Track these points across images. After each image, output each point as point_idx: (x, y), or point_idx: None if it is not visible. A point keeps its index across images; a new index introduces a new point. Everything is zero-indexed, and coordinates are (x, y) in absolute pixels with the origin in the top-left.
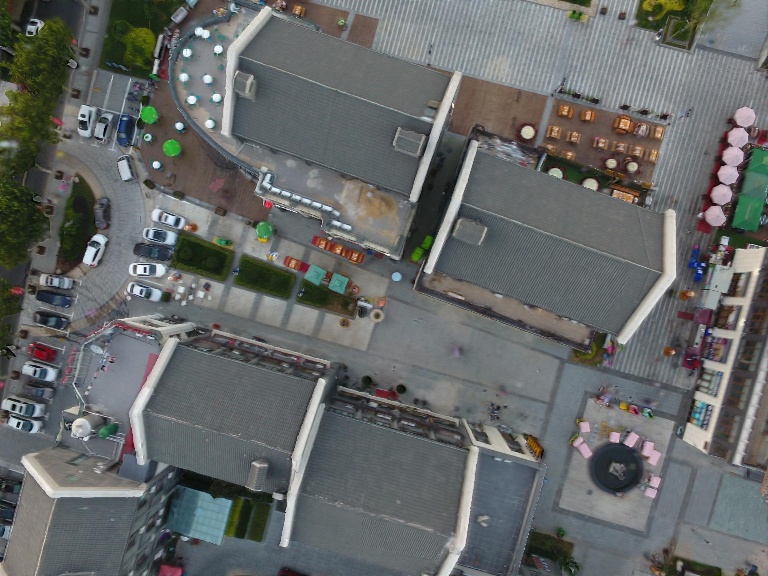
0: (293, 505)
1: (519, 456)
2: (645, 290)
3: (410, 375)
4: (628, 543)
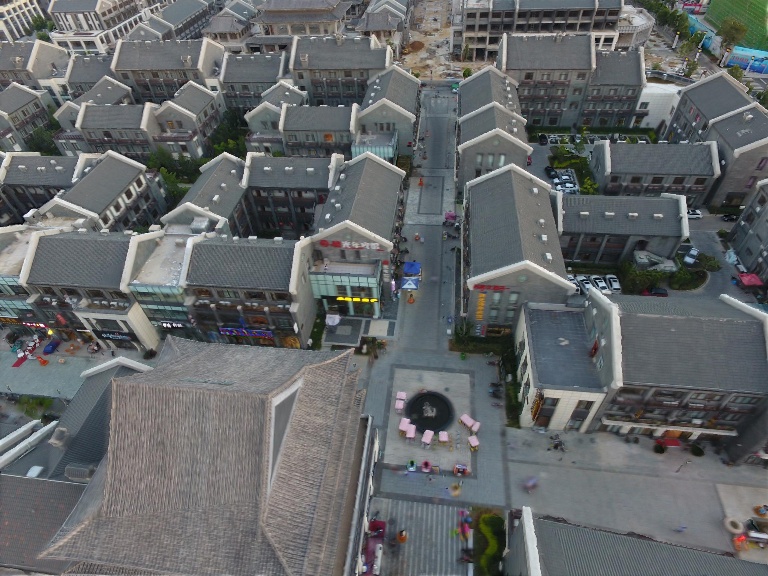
0: (759, 313)
1: (560, 392)
2: (544, 568)
3: (655, 466)
4: (406, 358)
